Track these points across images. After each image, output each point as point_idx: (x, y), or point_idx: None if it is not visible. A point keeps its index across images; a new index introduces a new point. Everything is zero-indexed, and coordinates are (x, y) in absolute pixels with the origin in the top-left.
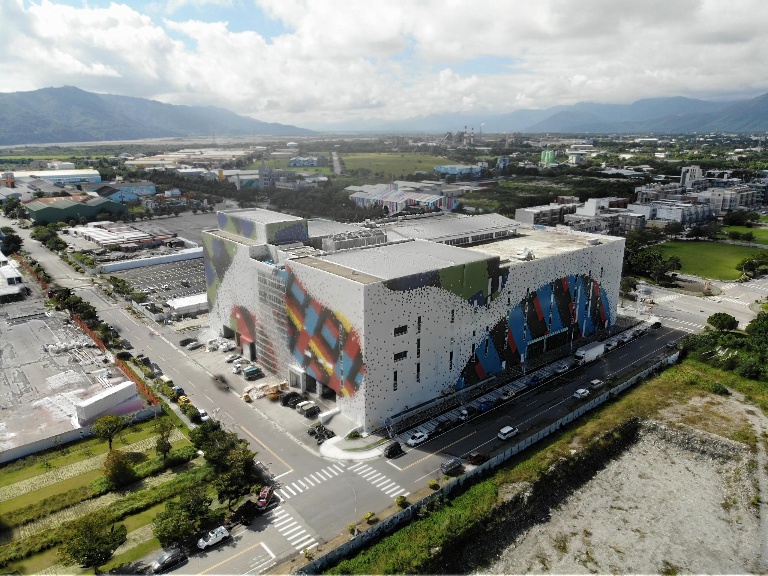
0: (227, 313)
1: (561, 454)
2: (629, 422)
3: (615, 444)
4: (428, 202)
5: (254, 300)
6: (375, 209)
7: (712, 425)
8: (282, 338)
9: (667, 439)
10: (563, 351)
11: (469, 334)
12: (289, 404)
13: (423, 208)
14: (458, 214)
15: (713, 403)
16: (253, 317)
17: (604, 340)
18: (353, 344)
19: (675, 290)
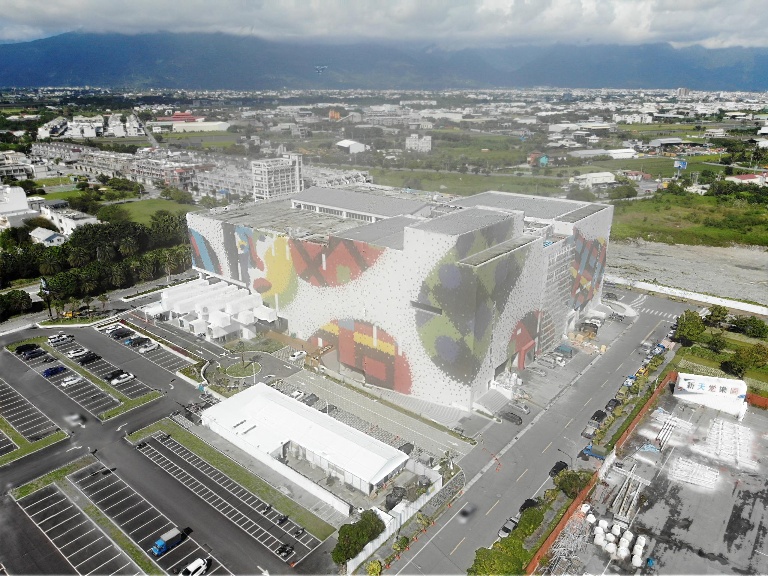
0: None
1: None
2: None
3: None
4: None
5: None
6: None
7: None
8: None
9: None
10: None
11: None
12: None
13: None
14: (211, 210)
15: None
16: None
17: None
18: None
19: None
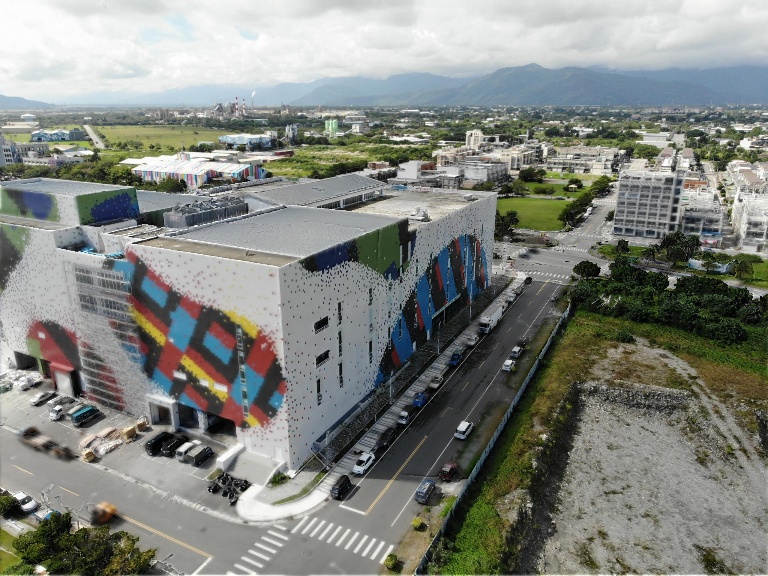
0: (20, 333)
1: (535, 443)
2: (571, 389)
3: (569, 416)
4: (233, 173)
5: (71, 309)
6: (172, 183)
7: (644, 376)
8: (131, 359)
9: (611, 400)
10: (461, 320)
11: (385, 316)
12: (162, 452)
13: (229, 180)
14: None
15: (629, 352)
16: (71, 334)
17: (492, 302)
18: (263, 353)
19: (520, 244)
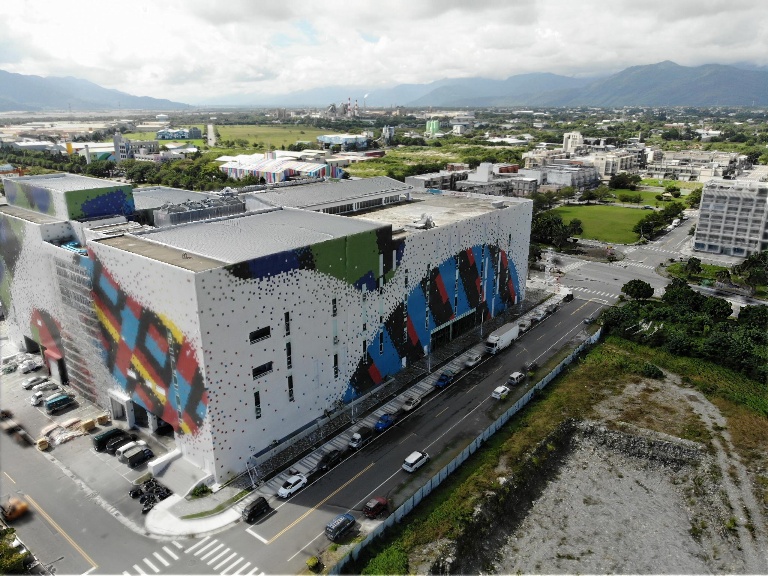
0: (26, 319)
1: (487, 487)
2: (562, 426)
3: (549, 459)
4: (309, 172)
5: (55, 300)
6: (249, 181)
7: (657, 420)
8: (95, 353)
9: (608, 444)
10: (472, 337)
11: (358, 329)
12: (106, 449)
13: None
14: None
15: (650, 390)
16: (57, 324)
17: (516, 319)
18: (188, 360)
19: (579, 257)
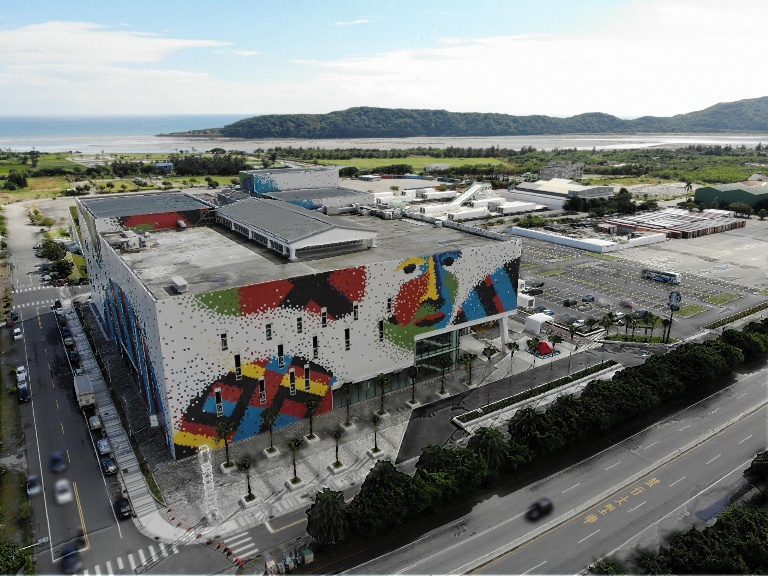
0: None
1: None
2: None
3: None
4: None
5: None
6: None
7: None
8: None
9: None
10: (123, 385)
11: None
12: None
13: None
14: (493, 244)
15: None
16: None
17: (125, 426)
18: None
19: None
